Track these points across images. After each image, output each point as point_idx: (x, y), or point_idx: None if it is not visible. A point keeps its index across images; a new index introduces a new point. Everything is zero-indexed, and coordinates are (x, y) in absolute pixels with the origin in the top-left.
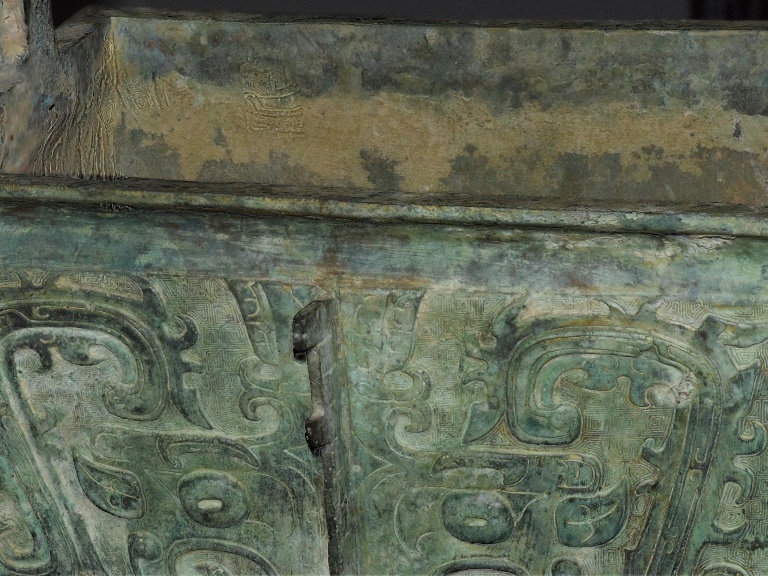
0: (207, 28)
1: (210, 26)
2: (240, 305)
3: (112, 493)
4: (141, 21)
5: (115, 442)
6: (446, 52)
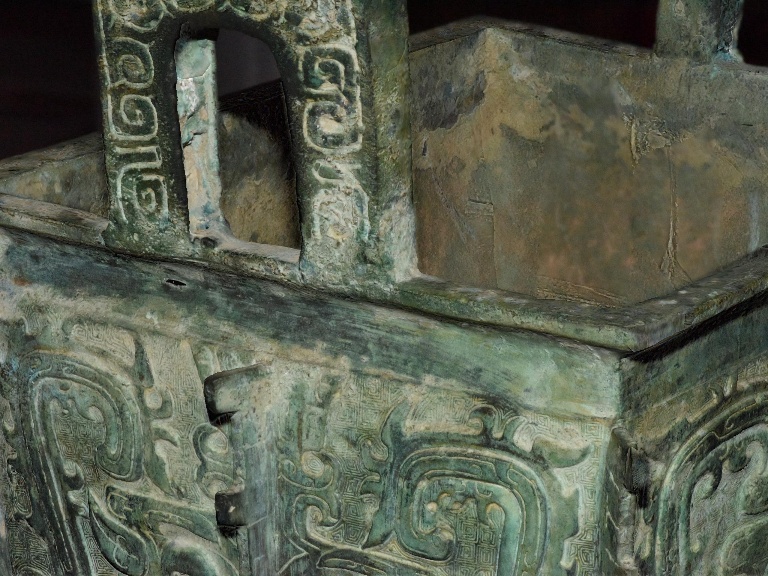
0: (58, 172)
1: (60, 169)
2: None
3: None
4: (4, 183)
5: (743, 546)
6: (242, 136)
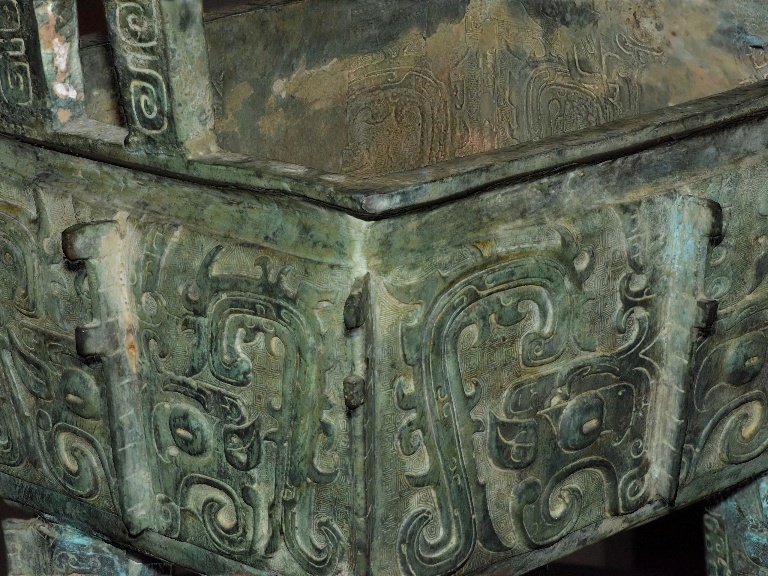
0: None
1: None
2: None
3: None
4: None
5: None
6: None
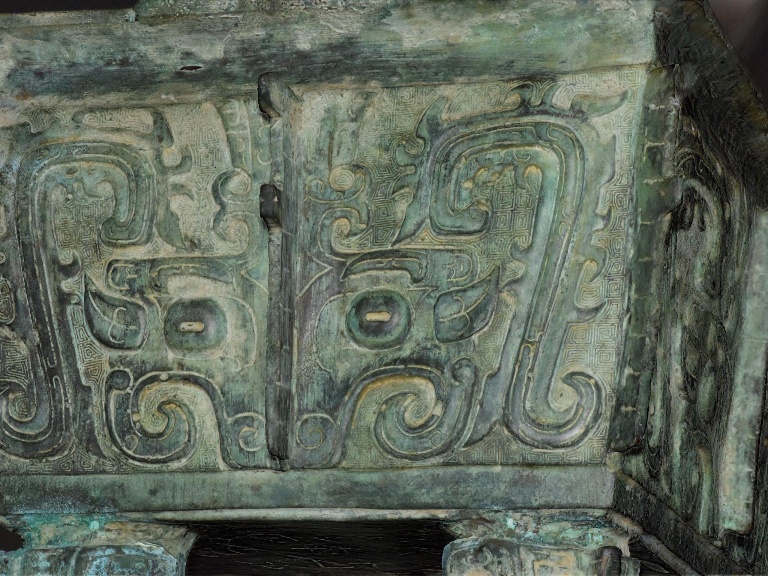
0: None
1: None
2: (741, 202)
3: (686, 371)
4: None
5: None
6: None
